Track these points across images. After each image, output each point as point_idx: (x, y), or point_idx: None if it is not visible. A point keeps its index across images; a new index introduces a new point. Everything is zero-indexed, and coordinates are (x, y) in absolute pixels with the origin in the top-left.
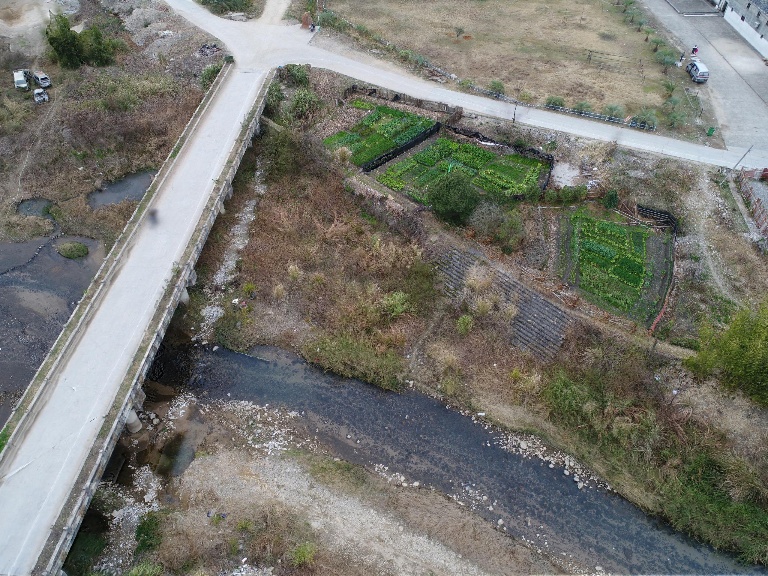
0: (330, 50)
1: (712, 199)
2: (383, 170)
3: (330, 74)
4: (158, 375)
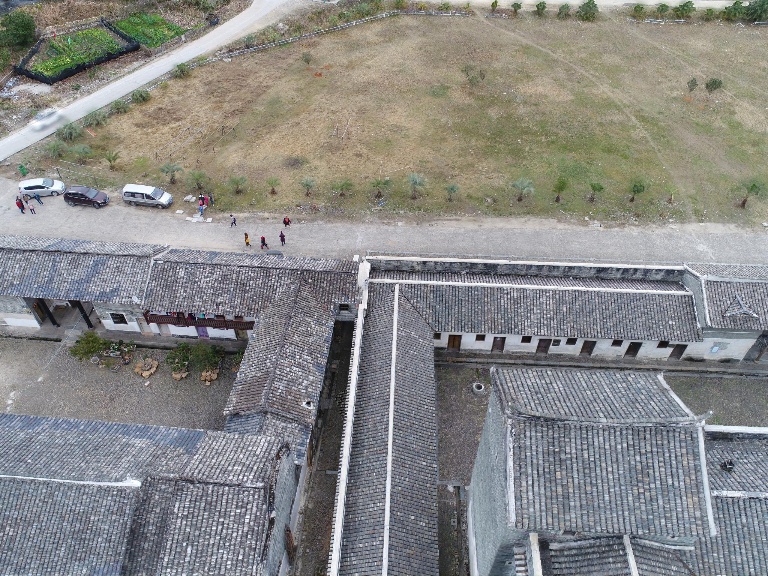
0: (282, 6)
1: None
2: (105, 31)
3: (238, 7)
4: (14, 1)
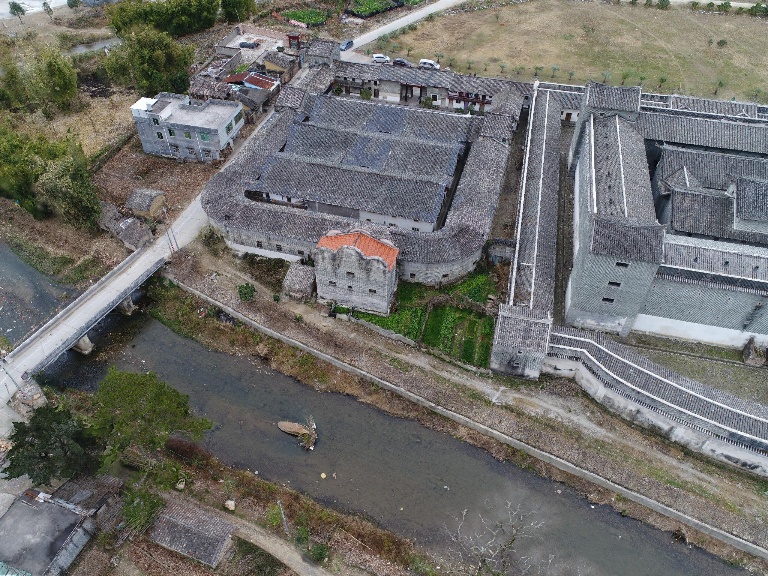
0: None
1: (322, 37)
2: None
3: None
4: None
